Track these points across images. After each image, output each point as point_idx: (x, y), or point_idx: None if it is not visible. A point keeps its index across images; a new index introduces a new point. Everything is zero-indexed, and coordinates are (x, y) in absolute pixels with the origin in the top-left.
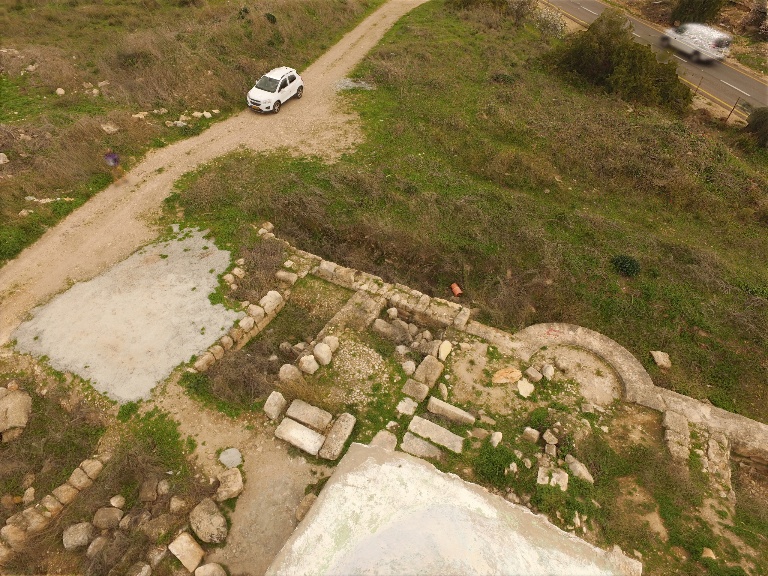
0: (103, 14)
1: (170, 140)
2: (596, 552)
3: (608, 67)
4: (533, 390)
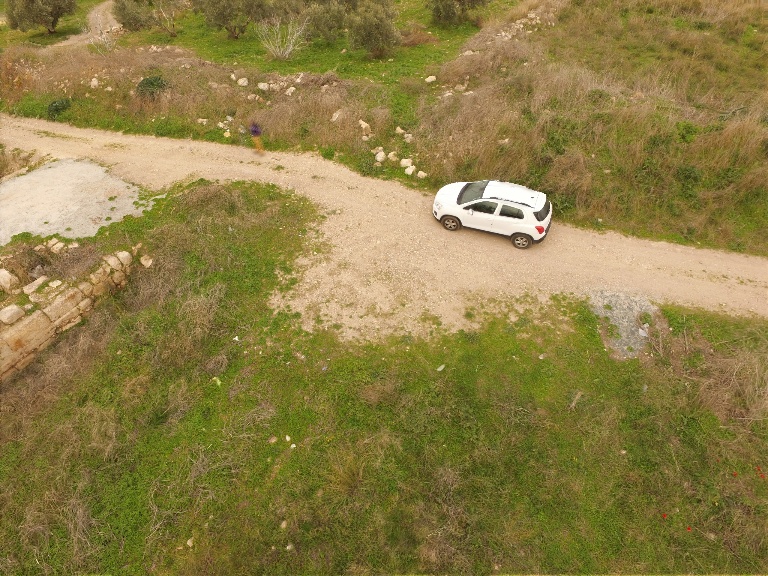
0: (682, 45)
1: (341, 159)
2: None
3: None
4: None
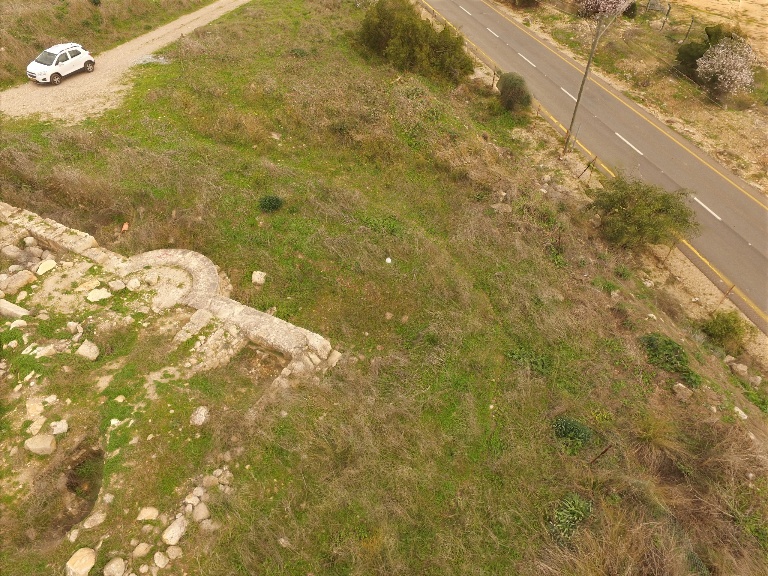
0: None
1: None
2: None
3: None
4: (108, 297)
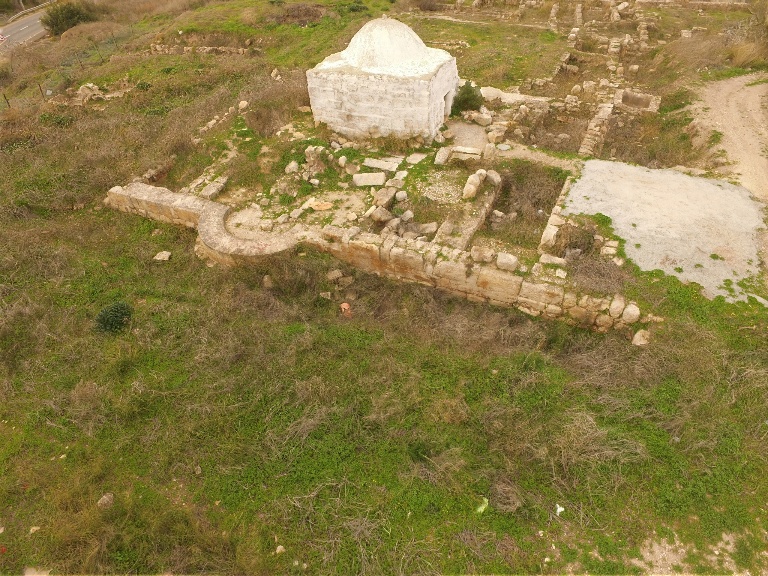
0: None
1: None
2: None
3: None
4: None
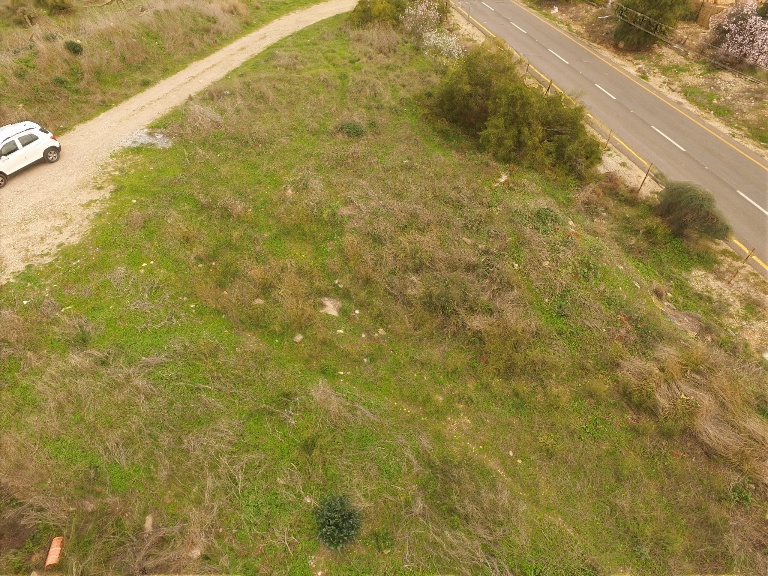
0: None
1: None
2: None
3: (487, 115)
4: None
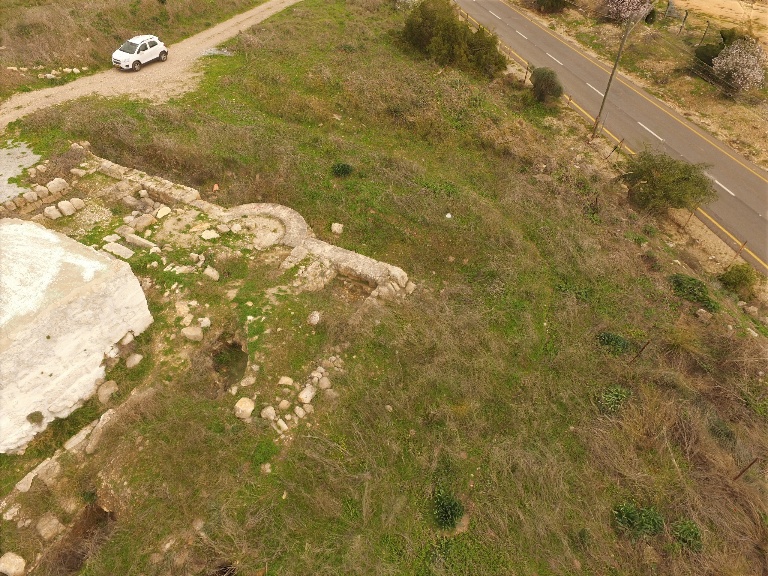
0: None
1: (36, 87)
2: (107, 259)
3: None
4: (217, 237)
